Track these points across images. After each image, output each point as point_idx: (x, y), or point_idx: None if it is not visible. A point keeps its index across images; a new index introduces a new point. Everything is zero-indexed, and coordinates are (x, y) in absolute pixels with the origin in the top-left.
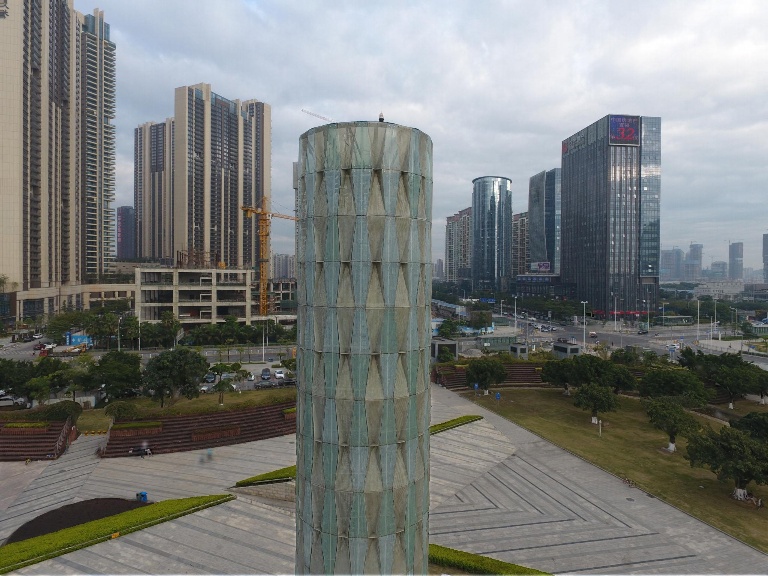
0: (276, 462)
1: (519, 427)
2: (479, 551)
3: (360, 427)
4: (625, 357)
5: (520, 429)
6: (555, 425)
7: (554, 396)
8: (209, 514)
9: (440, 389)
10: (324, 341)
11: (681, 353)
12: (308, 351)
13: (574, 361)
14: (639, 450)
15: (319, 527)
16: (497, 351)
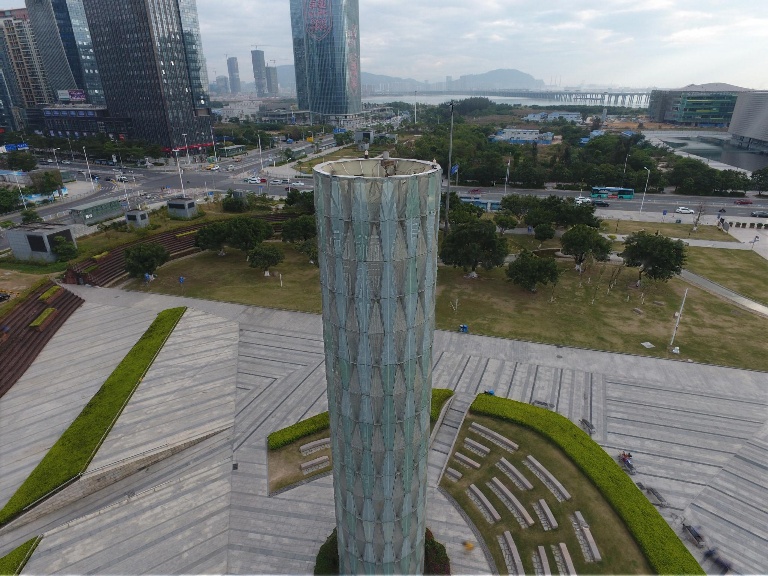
0: (1, 473)
1: (218, 302)
2: (299, 416)
3: (422, 396)
4: (236, 202)
5: (221, 304)
6: (243, 289)
7: (214, 260)
8: (34, 575)
9: (93, 290)
10: (405, 355)
11: (288, 195)
12: (386, 366)
13: (232, 226)
14: (313, 287)
15: (397, 471)
16: (103, 221)
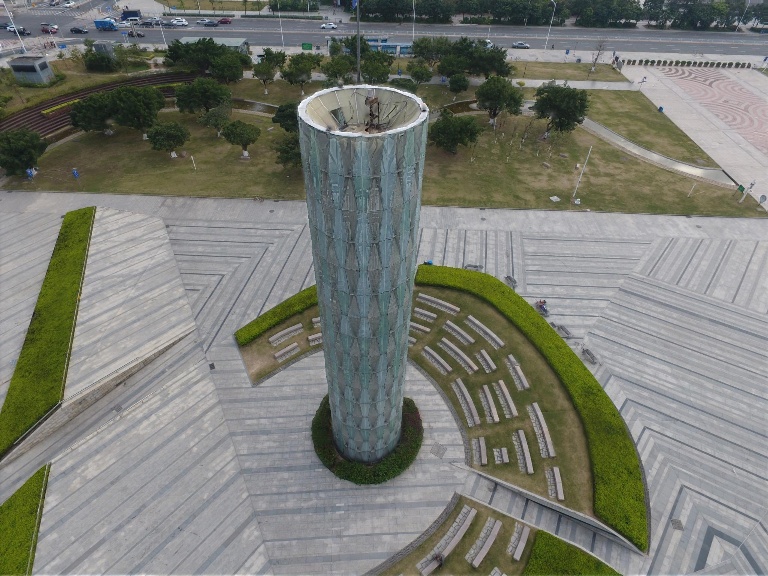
0: None
1: (128, 196)
2: (258, 310)
3: None
4: (102, 59)
5: (133, 198)
6: (151, 176)
7: (102, 141)
8: (59, 496)
9: None
10: (398, 281)
11: (169, 49)
12: None
13: (117, 100)
14: (231, 167)
15: (388, 366)
16: None
